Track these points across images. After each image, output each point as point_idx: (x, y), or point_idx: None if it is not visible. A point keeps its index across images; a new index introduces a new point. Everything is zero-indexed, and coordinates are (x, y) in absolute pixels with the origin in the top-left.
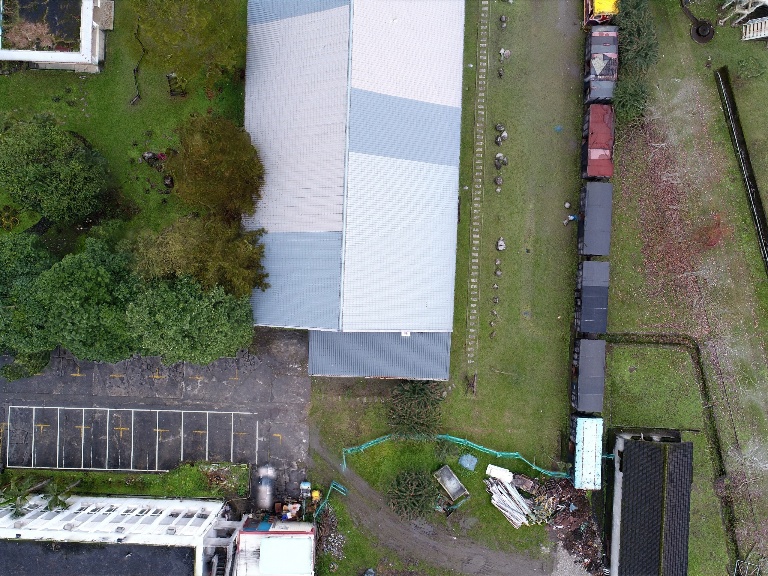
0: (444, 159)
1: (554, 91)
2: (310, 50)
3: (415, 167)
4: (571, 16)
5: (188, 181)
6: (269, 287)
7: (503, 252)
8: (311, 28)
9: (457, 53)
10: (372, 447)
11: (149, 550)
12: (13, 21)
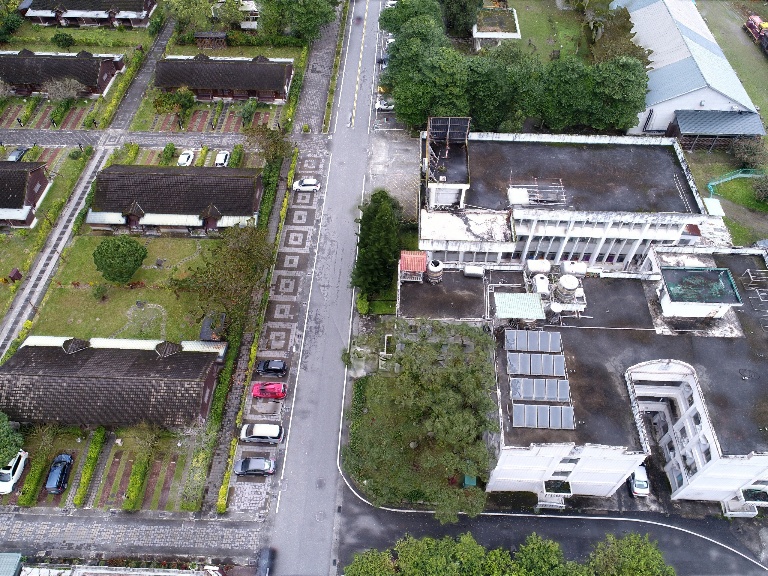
0: (720, 56)
1: (753, 60)
2: (643, 18)
3: (710, 53)
4: (746, 41)
5: (610, 37)
6: (650, 90)
7: (759, 112)
8: (641, 13)
9: (708, 30)
10: (725, 184)
11: (643, 149)
12: (482, 26)
